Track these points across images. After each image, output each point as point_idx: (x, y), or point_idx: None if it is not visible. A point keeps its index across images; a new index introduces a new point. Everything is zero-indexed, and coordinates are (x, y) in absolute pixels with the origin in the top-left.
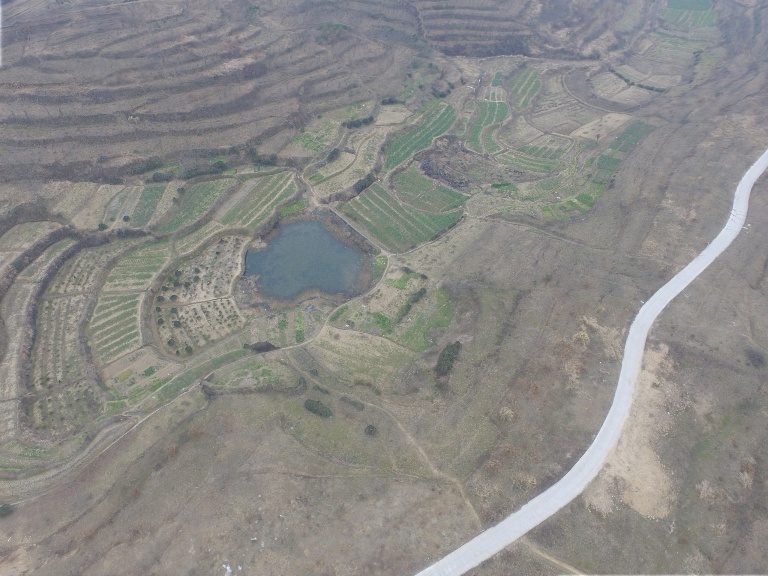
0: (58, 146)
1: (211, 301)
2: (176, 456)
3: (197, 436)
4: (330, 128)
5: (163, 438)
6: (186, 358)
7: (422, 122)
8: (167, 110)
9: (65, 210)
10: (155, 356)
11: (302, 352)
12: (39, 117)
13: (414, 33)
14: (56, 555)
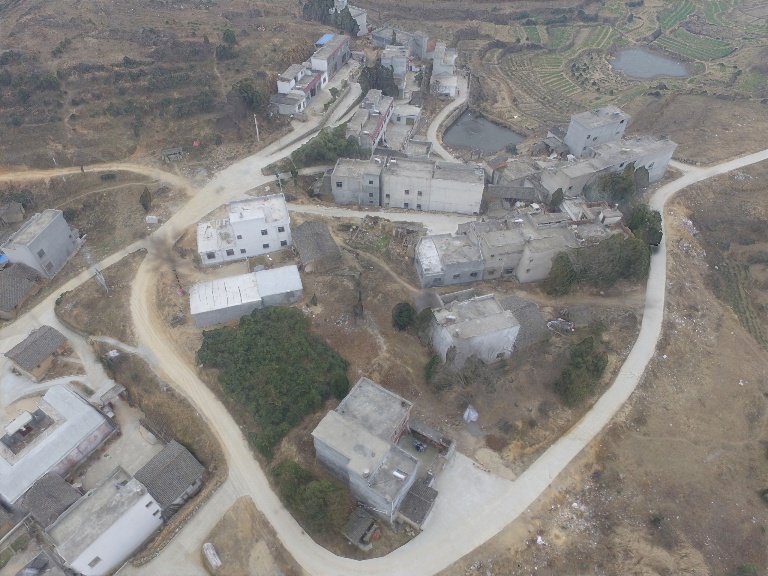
0: (463, 2)
1: (604, 77)
2: (668, 106)
3: (673, 100)
4: (620, 5)
5: (644, 108)
6: None
7: (673, 8)
8: None
9: (489, 33)
10: (595, 93)
11: (687, 90)
12: None
13: None
14: None
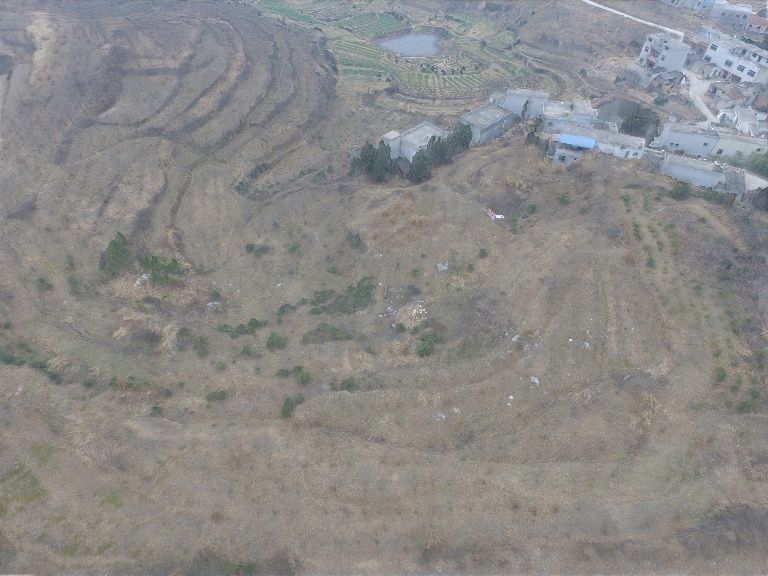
0: None
1: None
2: None
3: None
4: (289, 27)
5: None
6: (485, 67)
7: None
8: (270, 47)
9: (371, 89)
10: None
11: (486, 36)
12: (269, 78)
13: (149, 1)
14: (597, 57)
